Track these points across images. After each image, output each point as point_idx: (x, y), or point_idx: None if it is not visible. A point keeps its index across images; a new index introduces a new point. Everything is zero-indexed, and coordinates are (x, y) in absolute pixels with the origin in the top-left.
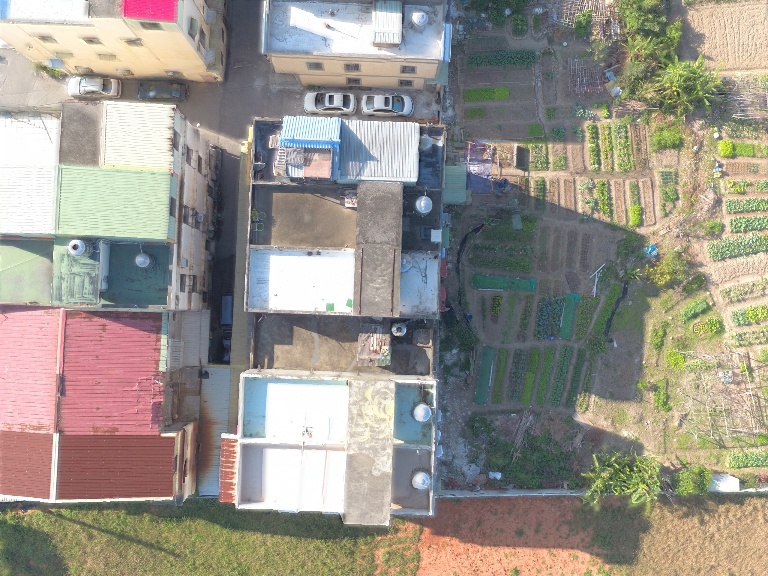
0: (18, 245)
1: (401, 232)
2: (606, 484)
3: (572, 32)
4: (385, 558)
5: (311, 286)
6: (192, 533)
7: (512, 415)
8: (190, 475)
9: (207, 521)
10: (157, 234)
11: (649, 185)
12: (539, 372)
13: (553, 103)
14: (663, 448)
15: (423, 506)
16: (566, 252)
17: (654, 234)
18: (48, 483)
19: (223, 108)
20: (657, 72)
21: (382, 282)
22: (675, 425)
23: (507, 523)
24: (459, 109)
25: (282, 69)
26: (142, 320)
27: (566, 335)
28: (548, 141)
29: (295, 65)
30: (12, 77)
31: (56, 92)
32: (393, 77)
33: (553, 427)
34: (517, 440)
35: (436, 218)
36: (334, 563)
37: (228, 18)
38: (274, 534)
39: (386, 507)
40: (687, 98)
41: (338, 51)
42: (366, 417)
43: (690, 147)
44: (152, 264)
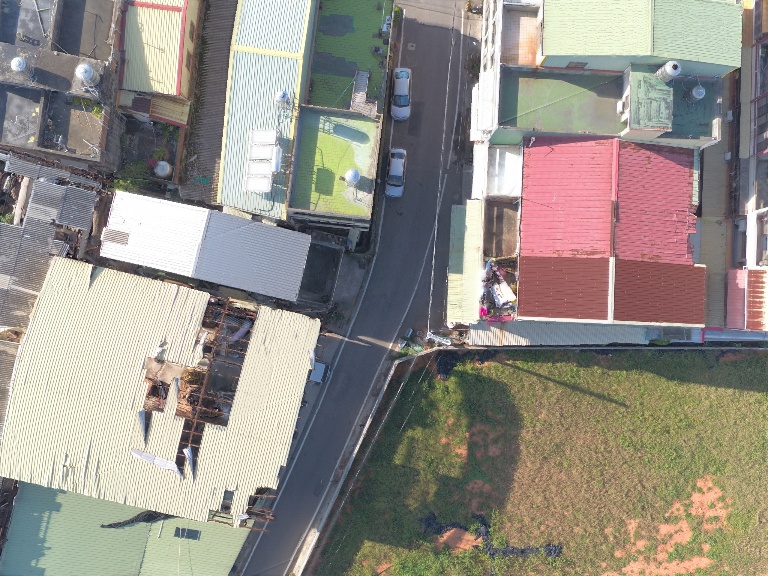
0: (566, 79)
1: None
2: None
3: None
4: None
5: None
6: (641, 386)
7: None
8: None
9: (655, 374)
10: (736, 61)
11: None
12: None
13: None
14: None
15: None
16: None
17: None
18: (606, 304)
19: None
20: None
21: None
22: None
23: None
24: None
25: None
26: (679, 155)
27: None
28: None
29: None
30: None
31: None
32: None
33: None
34: None
35: None
36: None
37: None
38: (718, 387)
39: None
40: None
41: None
42: None
43: None
44: None
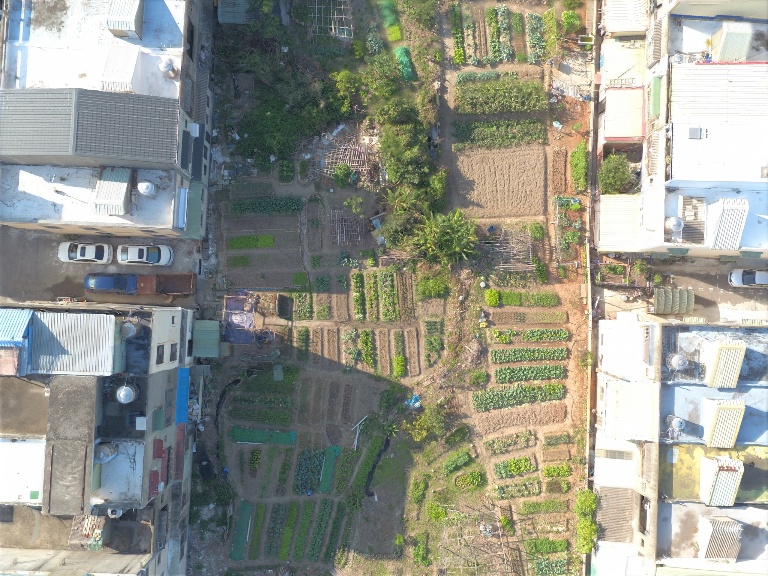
0: None
1: (94, 428)
2: None
3: None
4: None
5: (15, 473)
6: None
7: (269, 571)
8: None
9: None
10: None
11: (414, 335)
12: (298, 527)
13: (318, 251)
14: None
15: None
16: (327, 404)
17: (418, 385)
18: None
19: None
20: (416, 225)
21: (73, 480)
22: None
23: None
24: (222, 256)
25: (21, 227)
26: None
27: (326, 489)
28: (313, 290)
29: (30, 226)
30: None
31: None
32: (140, 233)
33: None
34: None
35: (146, 402)
36: None
37: None
38: None
39: None
40: (446, 252)
41: (67, 217)
42: None
43: (456, 297)
44: None
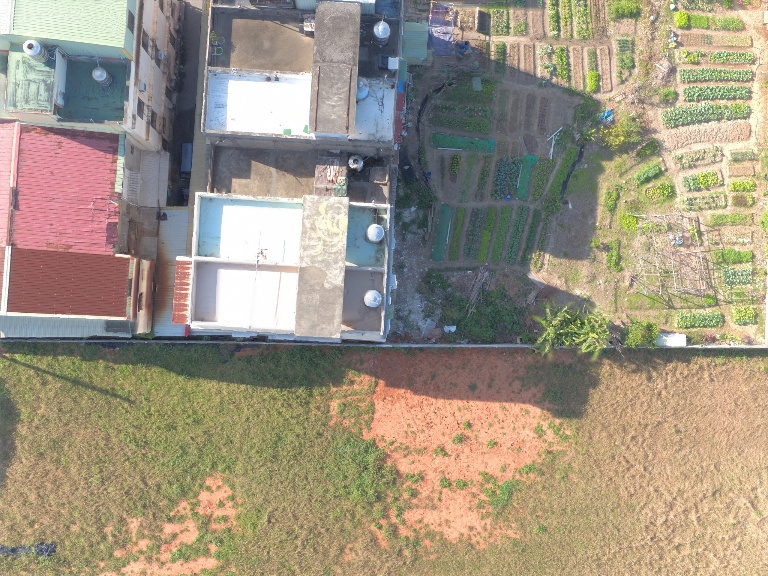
0: None
1: (358, 52)
2: (557, 335)
3: None
4: (340, 408)
5: (269, 112)
6: (148, 380)
7: (468, 272)
8: (146, 312)
9: (163, 369)
10: (113, 41)
11: (606, 53)
12: (496, 231)
13: None
14: (614, 307)
15: (375, 329)
16: (524, 115)
17: (610, 100)
18: None
19: None
20: None
21: (338, 100)
22: (626, 285)
23: (461, 377)
24: None
25: None
26: (98, 140)
27: (523, 195)
28: (509, 7)
29: None
30: None
31: None
32: None
33: (508, 283)
34: (472, 296)
35: (394, 49)
36: (290, 412)
37: None
38: (230, 382)
39: (337, 320)
40: None
41: None
42: (319, 231)
43: (647, 17)
44: (109, 81)
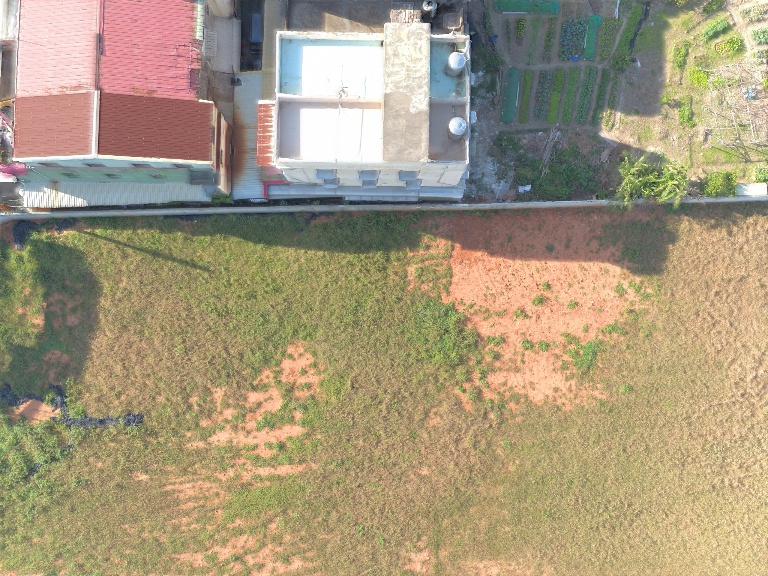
0: None
1: None
2: (635, 186)
3: None
4: (418, 273)
5: None
6: (226, 251)
7: (540, 133)
8: (225, 173)
9: (241, 239)
10: None
11: None
12: (565, 92)
13: None
14: (690, 162)
15: None
16: None
17: None
18: (90, 138)
19: None
20: None
21: None
22: (701, 139)
23: (538, 239)
24: None
25: None
26: None
27: (590, 55)
28: None
29: None
30: None
31: None
32: None
33: (581, 141)
34: (545, 156)
35: None
36: (368, 278)
37: None
38: (308, 250)
39: (425, 143)
40: None
41: None
42: (403, 57)
43: None
44: None
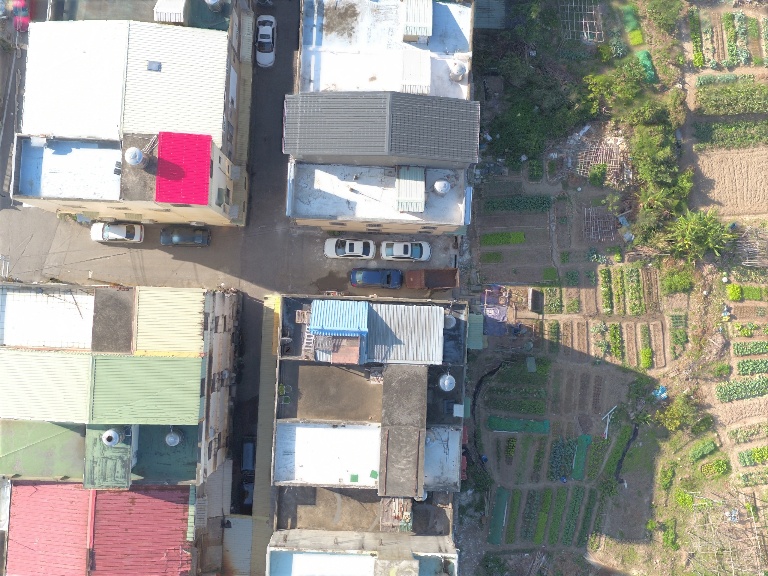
0: None
1: (426, 414)
2: None
3: (586, 178)
4: None
5: (336, 457)
6: None
7: (525, 555)
8: None
9: None
10: (188, 421)
11: (660, 328)
12: (552, 512)
13: (567, 247)
14: None
15: None
16: (579, 395)
17: (664, 376)
18: None
19: (244, 252)
20: (669, 222)
21: (407, 463)
22: (683, 564)
23: None
24: (475, 252)
25: (304, 223)
26: (170, 491)
27: (578, 476)
28: (562, 284)
29: (318, 222)
30: (35, 220)
31: (79, 235)
32: (413, 230)
33: (565, 568)
34: None
35: (458, 391)
36: None
37: (249, 162)
38: None
39: None
40: (698, 248)
41: (361, 214)
42: None
43: (700, 291)
44: (181, 440)
